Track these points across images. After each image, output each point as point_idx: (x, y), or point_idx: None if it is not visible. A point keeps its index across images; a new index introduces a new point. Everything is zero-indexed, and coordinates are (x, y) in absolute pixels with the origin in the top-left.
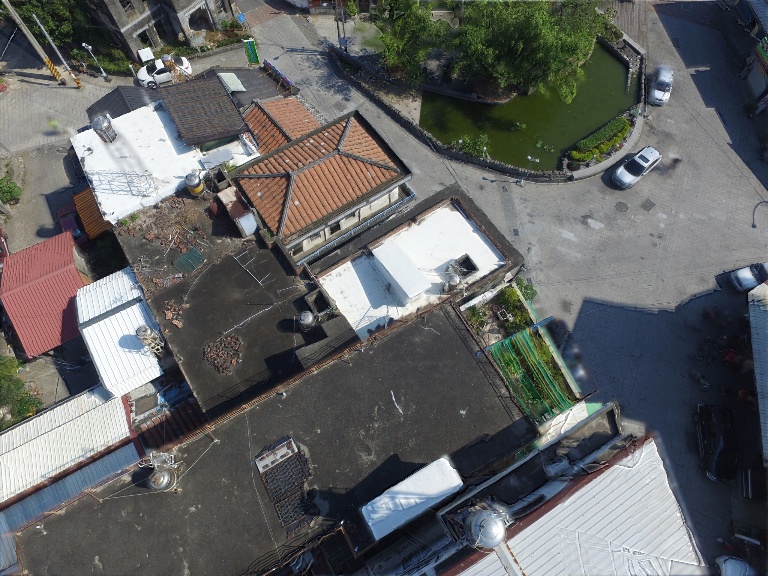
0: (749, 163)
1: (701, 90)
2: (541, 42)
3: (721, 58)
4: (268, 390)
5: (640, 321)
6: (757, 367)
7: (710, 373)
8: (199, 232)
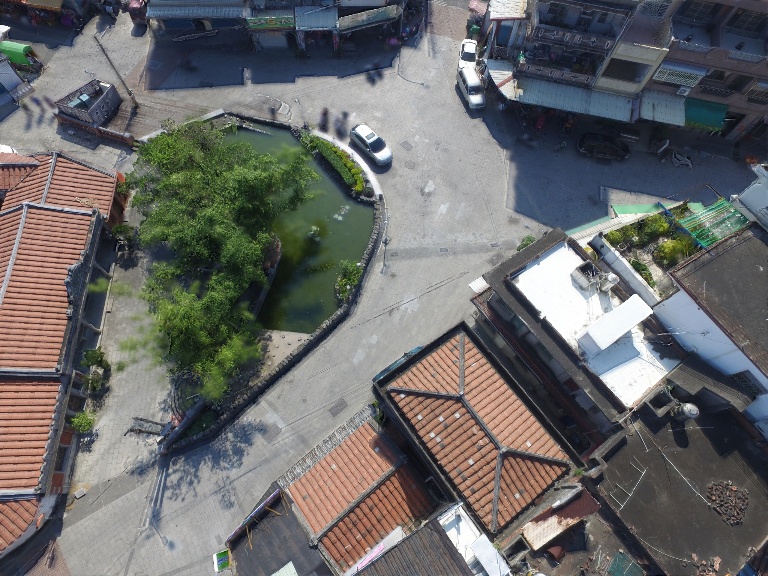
0: (359, 71)
1: (273, 81)
2: (273, 182)
3: (233, 58)
4: (746, 450)
5: (517, 173)
6: (567, 109)
7: (550, 140)
8: (587, 568)
